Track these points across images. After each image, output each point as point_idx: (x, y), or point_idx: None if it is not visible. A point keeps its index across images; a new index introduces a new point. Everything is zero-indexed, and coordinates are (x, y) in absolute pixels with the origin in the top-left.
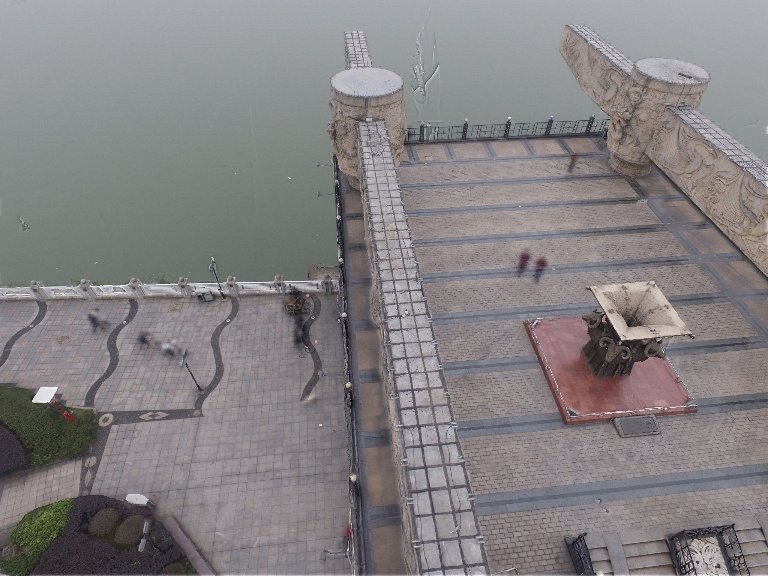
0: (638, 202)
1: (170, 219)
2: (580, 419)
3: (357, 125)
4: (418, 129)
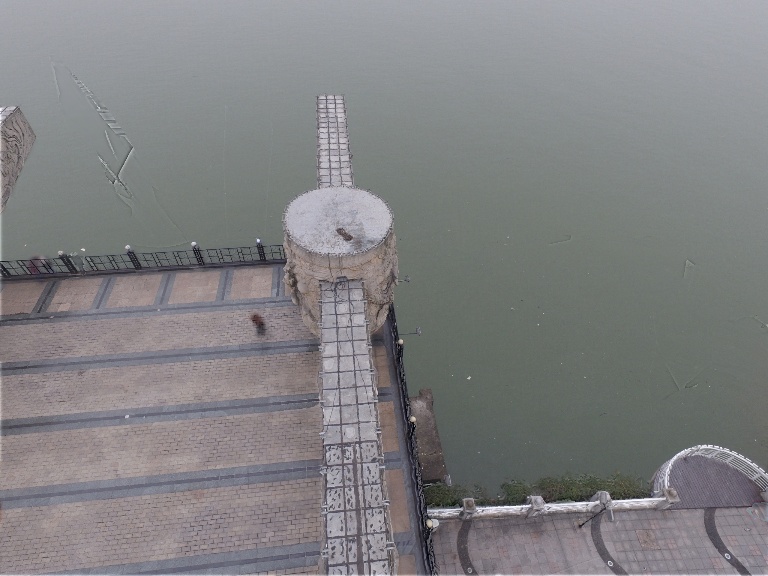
0: (317, 405)
1: None
2: None
3: None
4: (59, 259)
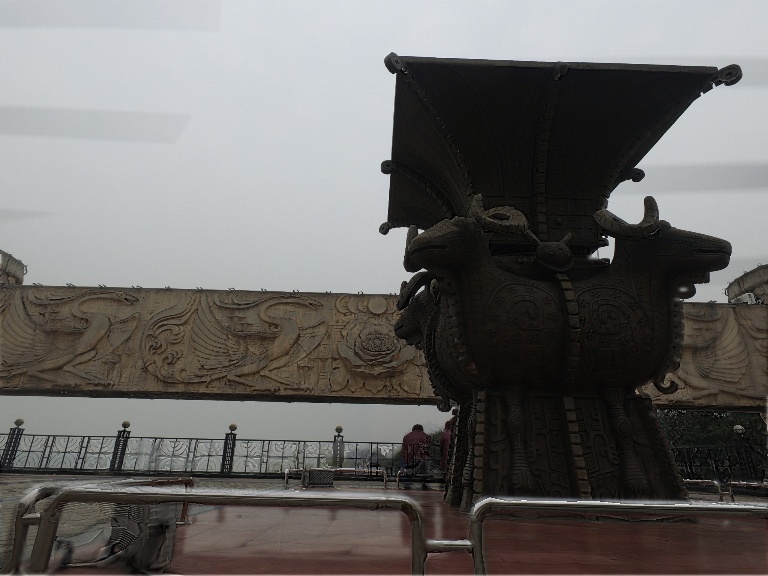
0: None
1: None
2: None
3: None
4: None
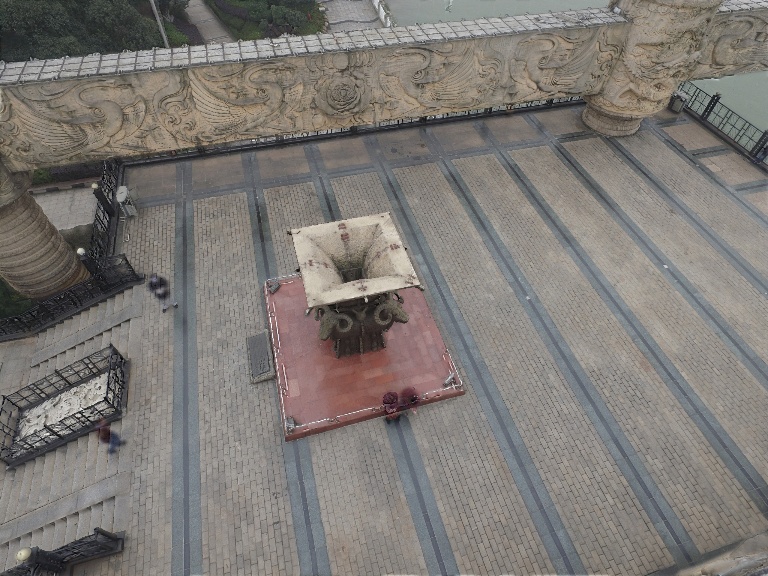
0: None
1: None
2: None
3: None
4: (761, 134)
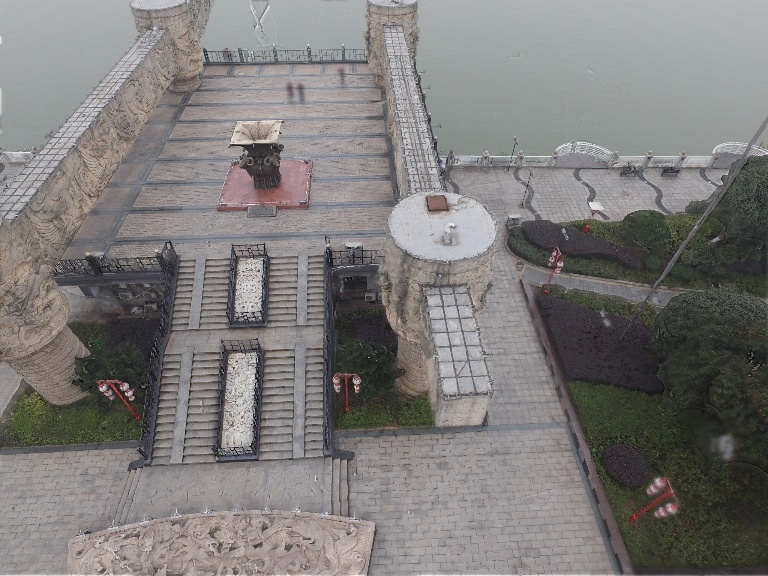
0: (377, 103)
1: (51, 119)
2: (226, 207)
3: (145, 32)
4: (237, 52)
